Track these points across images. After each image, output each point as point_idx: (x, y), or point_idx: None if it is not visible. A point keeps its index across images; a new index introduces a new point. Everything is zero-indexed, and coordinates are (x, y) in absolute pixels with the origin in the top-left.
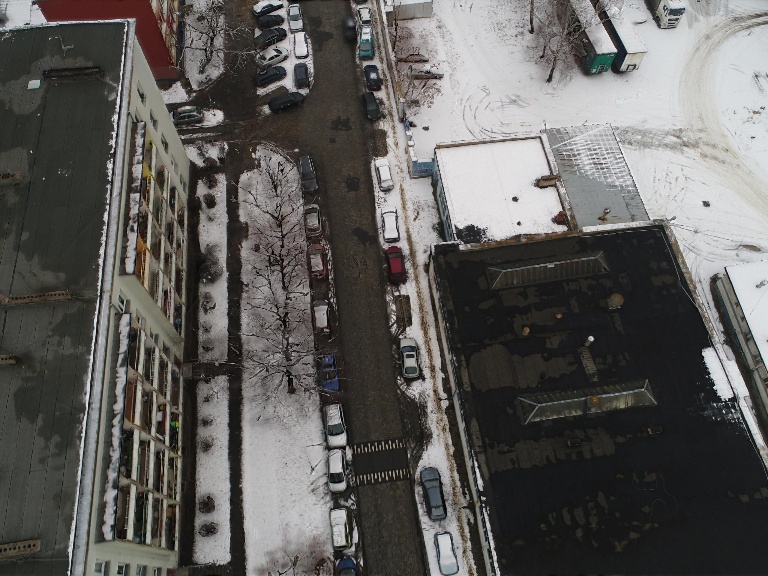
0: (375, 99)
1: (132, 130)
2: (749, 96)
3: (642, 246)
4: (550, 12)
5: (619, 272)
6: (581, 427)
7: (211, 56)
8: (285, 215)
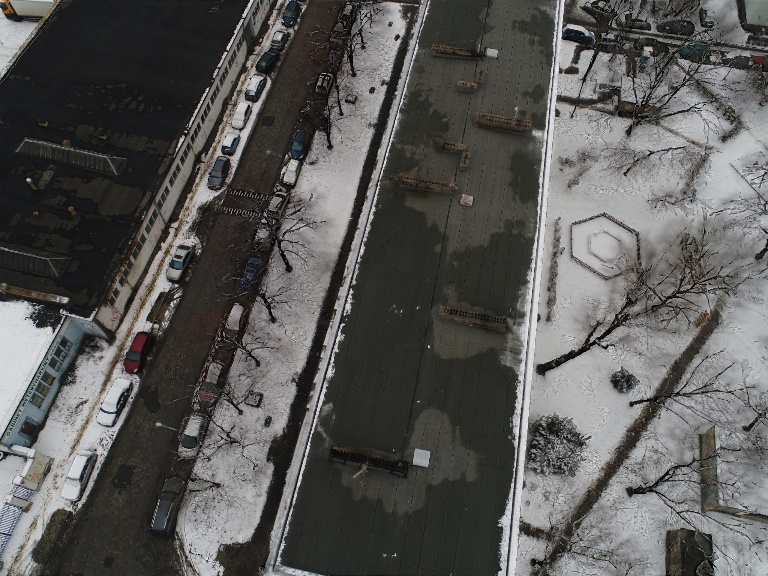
0: None
1: None
2: None
3: None
4: None
5: None
6: (90, 144)
7: None
8: None
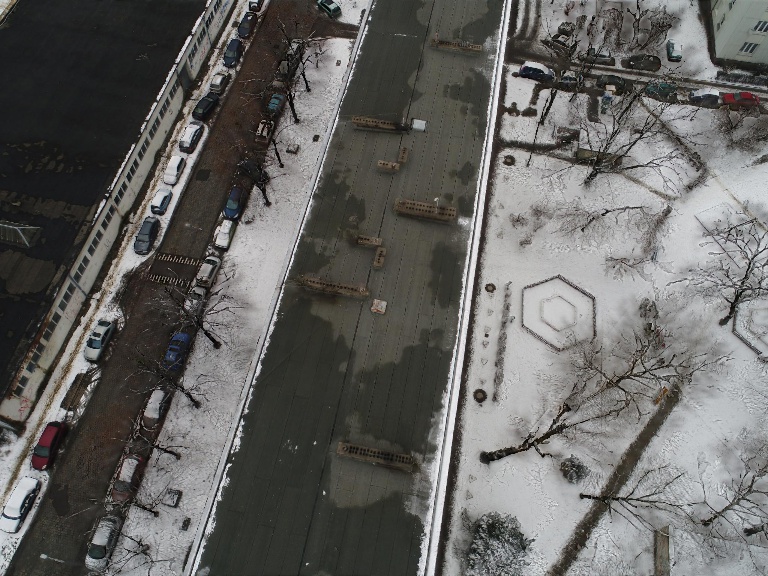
0: None
1: None
2: None
3: None
4: None
5: None
6: (1, 212)
7: None
8: None
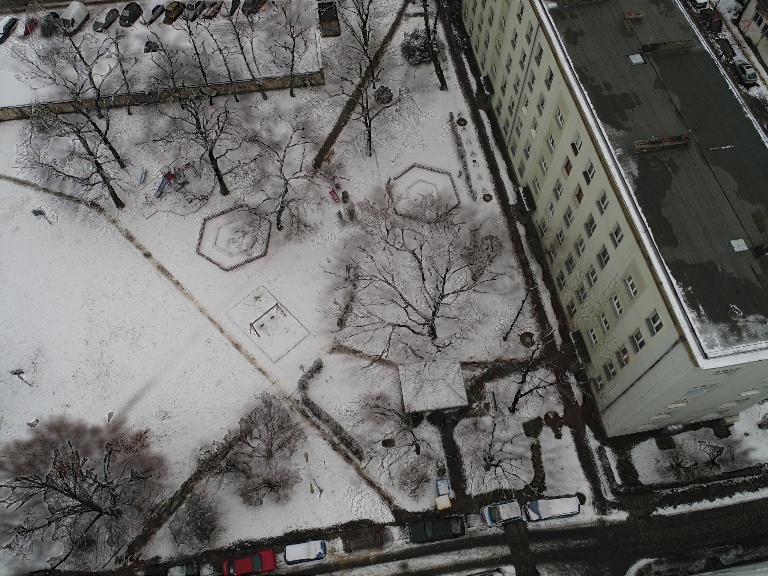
0: None
1: None
2: None
3: None
4: None
5: None
6: None
7: None
8: None
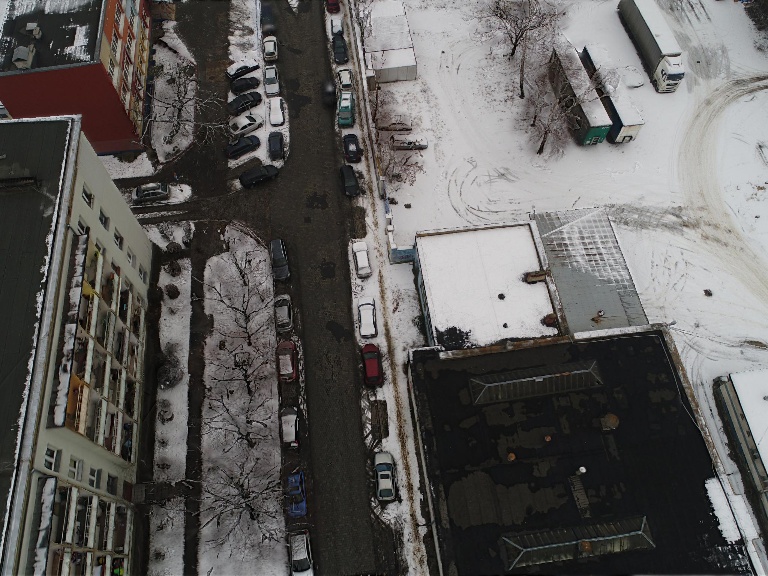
0: (354, 173)
1: (72, 245)
2: (753, 169)
3: (639, 355)
4: (542, 74)
5: (614, 386)
6: (571, 574)
7: (179, 126)
8: (253, 307)
